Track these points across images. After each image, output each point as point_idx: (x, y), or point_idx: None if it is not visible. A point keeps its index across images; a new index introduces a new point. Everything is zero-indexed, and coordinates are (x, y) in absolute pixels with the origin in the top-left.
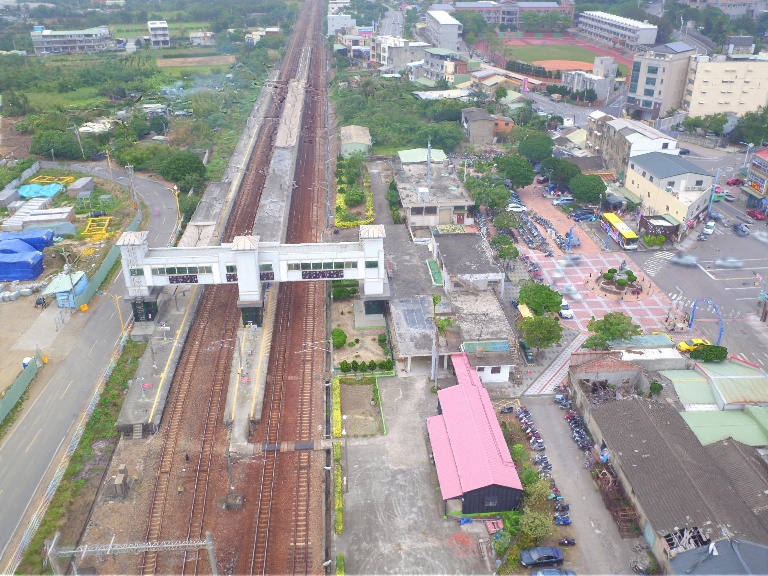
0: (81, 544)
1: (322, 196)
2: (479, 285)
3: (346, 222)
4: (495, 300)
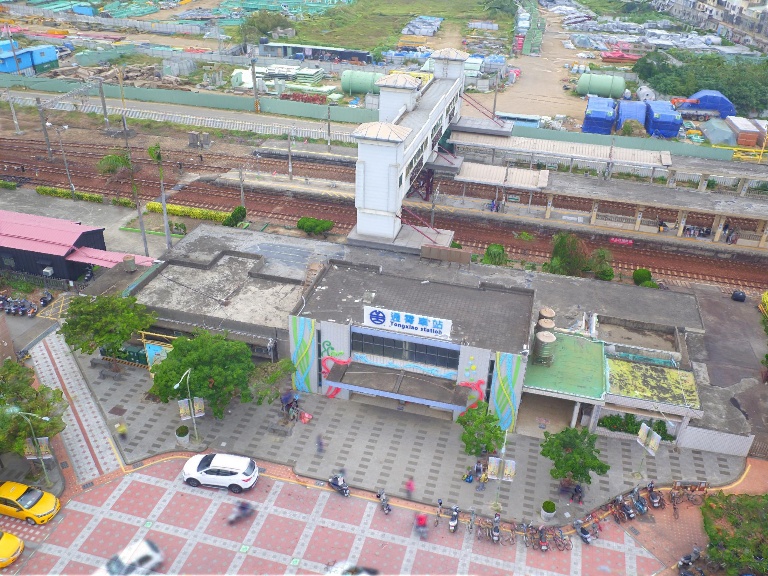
0: (161, 136)
1: None
2: None
3: None
4: None
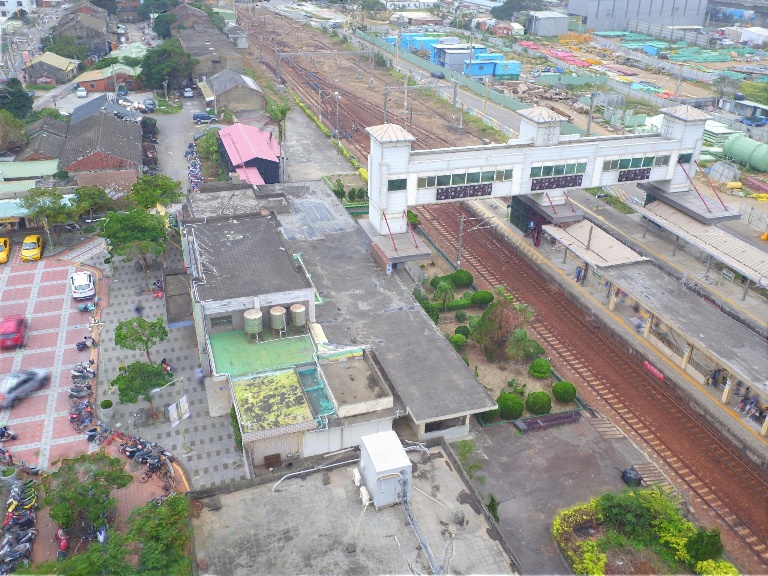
0: None
1: None
2: None
3: None
4: None
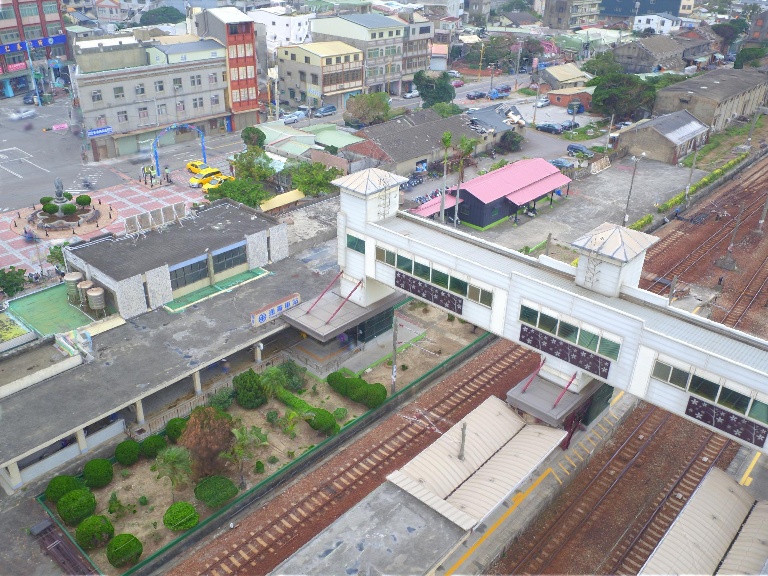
0: None
1: None
2: None
3: None
4: None
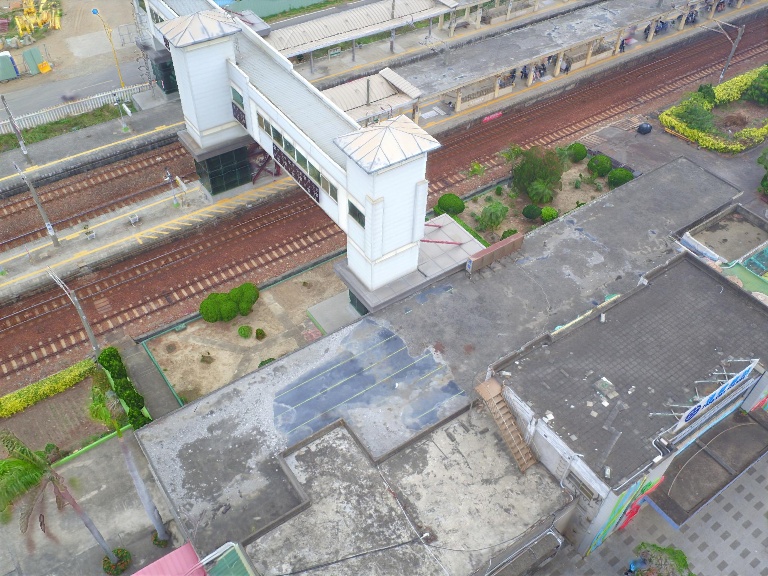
0: None
1: (760, 59)
2: (548, 455)
3: (681, 122)
4: (524, 527)
